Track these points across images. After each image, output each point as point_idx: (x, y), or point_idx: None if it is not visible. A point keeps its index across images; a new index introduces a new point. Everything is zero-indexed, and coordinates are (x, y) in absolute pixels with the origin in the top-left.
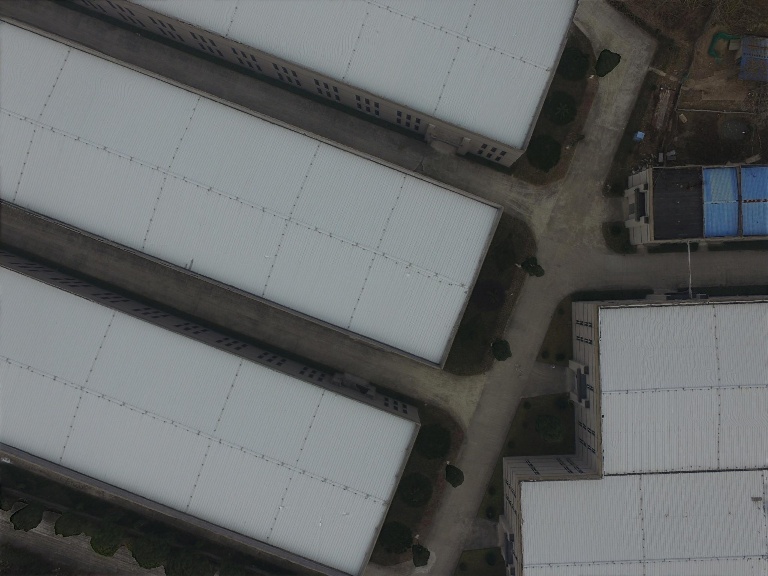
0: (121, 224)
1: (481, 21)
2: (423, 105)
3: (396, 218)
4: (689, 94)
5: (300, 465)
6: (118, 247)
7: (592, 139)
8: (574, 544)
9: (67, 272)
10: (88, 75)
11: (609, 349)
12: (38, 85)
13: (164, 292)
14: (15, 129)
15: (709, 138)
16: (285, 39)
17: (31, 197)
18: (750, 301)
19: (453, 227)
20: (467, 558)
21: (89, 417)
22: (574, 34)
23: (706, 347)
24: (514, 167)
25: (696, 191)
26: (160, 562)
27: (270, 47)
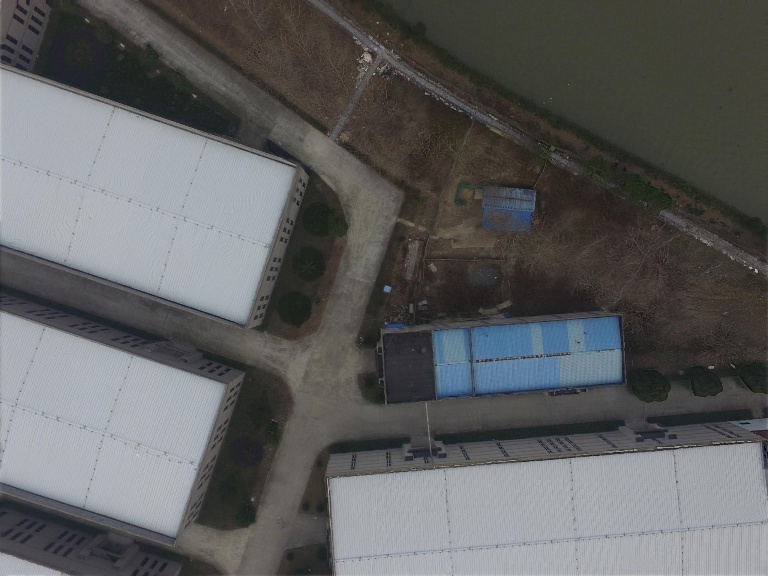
0: None
1: (198, 200)
2: (146, 284)
3: (124, 399)
4: (439, 243)
5: None
6: None
7: (344, 292)
8: None
9: None
10: None
11: (341, 517)
12: None
13: None
14: None
15: (459, 286)
16: None
17: None
18: (479, 463)
19: (181, 405)
20: None
21: None
22: (320, 189)
23: (437, 511)
24: (266, 324)
25: (428, 354)
26: None
27: None
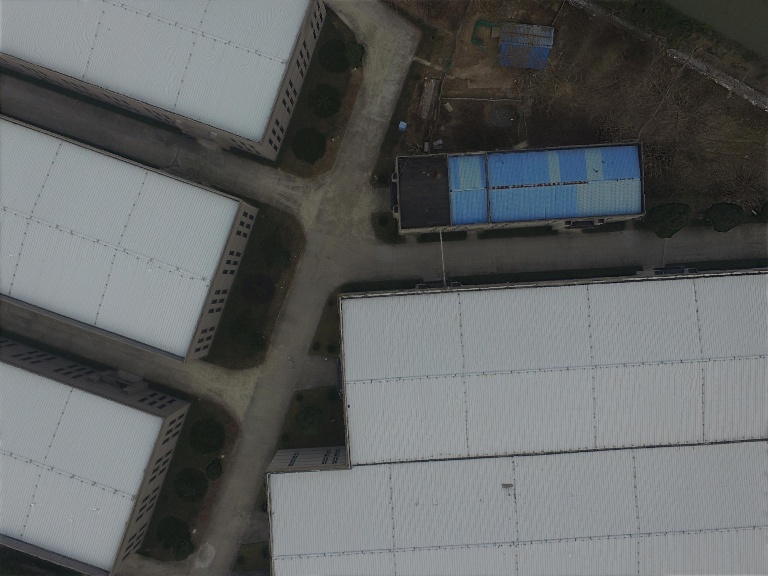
0: None
1: (216, 16)
2: (163, 101)
3: (137, 214)
4: (455, 83)
5: (48, 462)
6: None
7: (358, 130)
8: (324, 535)
9: None
10: None
11: (353, 339)
12: None
13: None
14: None
15: (475, 126)
16: (20, 39)
17: None
18: (494, 287)
19: (195, 221)
20: (245, 552)
21: None
22: (337, 26)
23: (451, 334)
24: (280, 160)
25: (443, 179)
26: None
27: (10, 48)
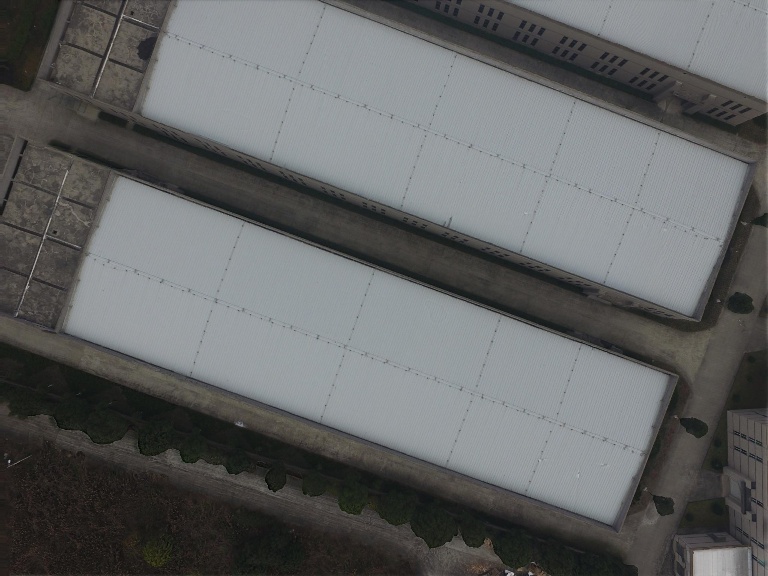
0: (380, 182)
1: None
2: (676, 62)
3: (652, 174)
4: None
5: (560, 418)
6: (381, 205)
7: None
8: None
9: (300, 235)
10: (350, 31)
11: None
12: (295, 42)
13: (396, 254)
14: (273, 87)
15: None
16: None
17: (288, 156)
18: None
19: (707, 182)
20: (693, 509)
21: (351, 375)
22: None
23: None
24: (739, 126)
25: None
26: (409, 518)
27: (526, 4)
